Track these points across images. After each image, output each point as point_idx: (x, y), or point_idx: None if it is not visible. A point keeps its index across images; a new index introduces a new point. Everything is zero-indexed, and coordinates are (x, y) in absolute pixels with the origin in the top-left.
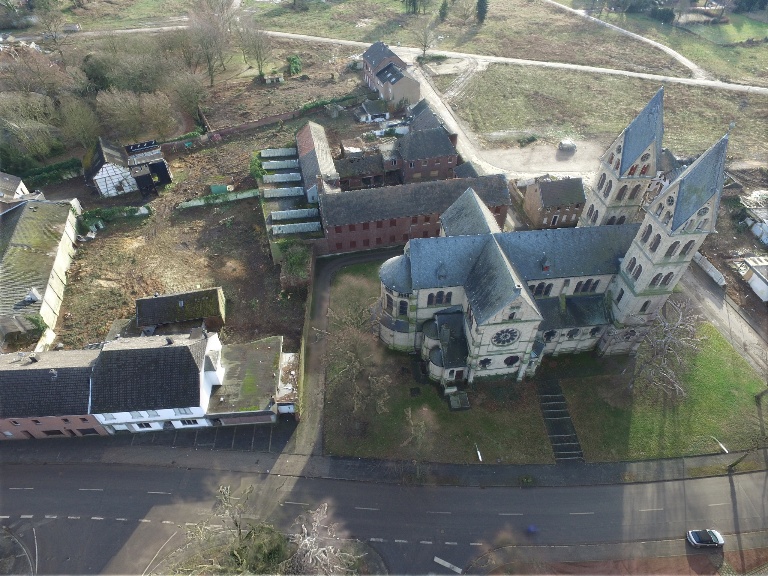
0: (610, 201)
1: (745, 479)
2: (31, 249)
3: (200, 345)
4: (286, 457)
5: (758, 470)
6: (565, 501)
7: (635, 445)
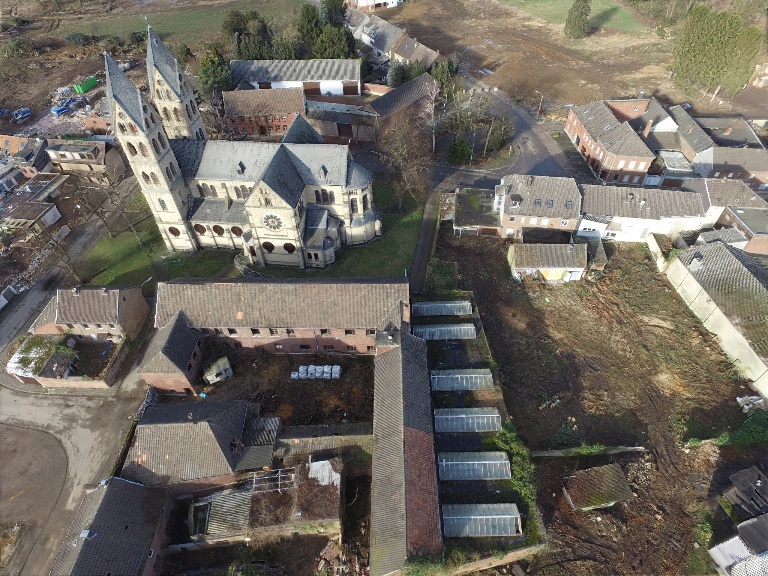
0: (168, 143)
1: None
2: (763, 319)
3: (508, 184)
4: (449, 188)
5: None
6: None
7: None
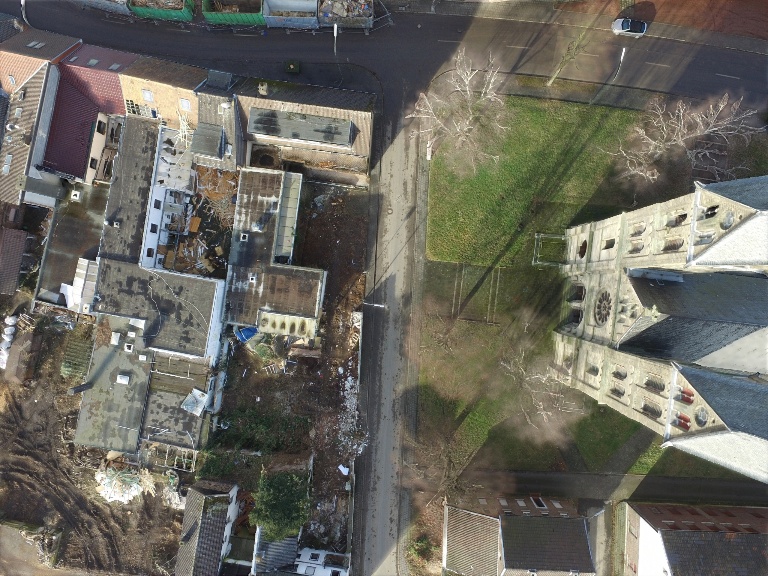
0: None
1: (543, 70)
2: None
3: None
4: None
5: (522, 75)
6: (738, 90)
7: (636, 125)
